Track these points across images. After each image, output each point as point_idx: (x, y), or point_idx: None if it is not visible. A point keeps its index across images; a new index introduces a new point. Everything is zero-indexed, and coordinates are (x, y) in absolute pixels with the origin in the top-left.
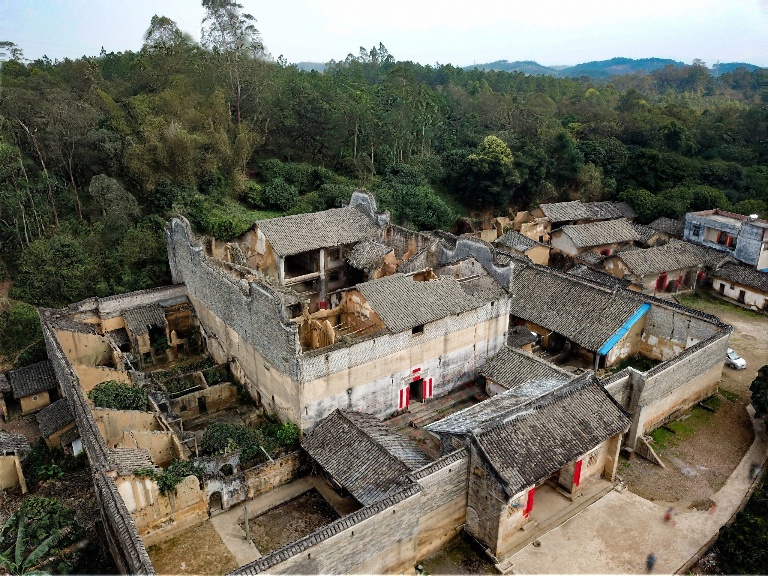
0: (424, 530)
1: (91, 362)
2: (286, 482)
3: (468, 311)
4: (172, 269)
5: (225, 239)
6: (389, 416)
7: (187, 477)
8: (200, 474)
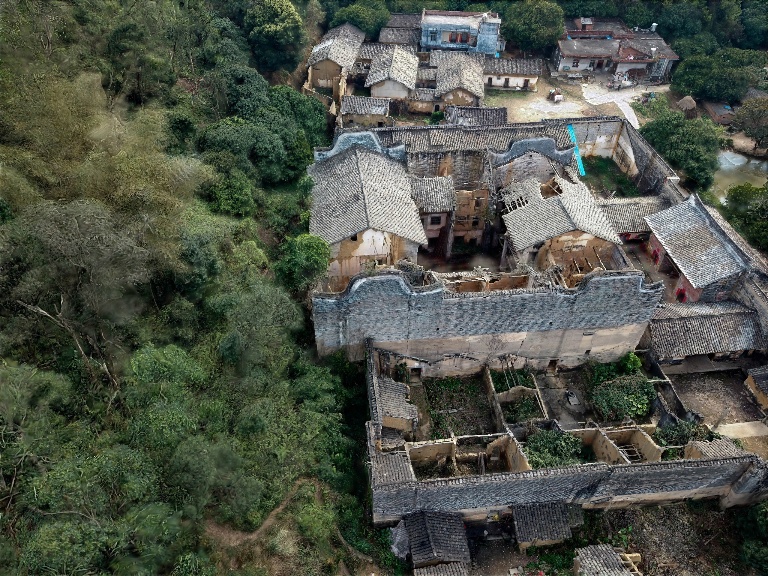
0: None
1: None
2: None
3: None
4: (324, 337)
5: None
6: None
7: None
8: None
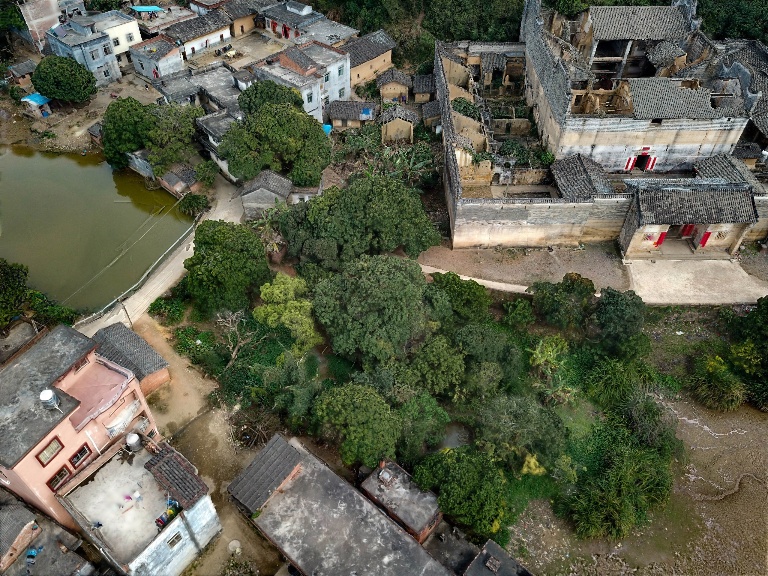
0: (591, 227)
1: (455, 82)
2: (535, 184)
3: (704, 119)
4: (521, 29)
5: (565, 14)
6: (616, 172)
7: (486, 160)
8: (493, 162)
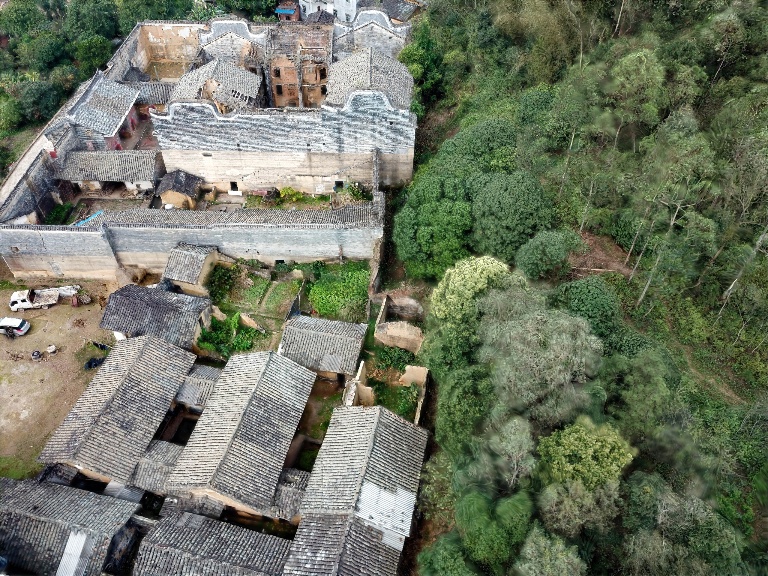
0: None
1: None
2: None
3: None
4: None
5: None
6: None
7: None
8: None
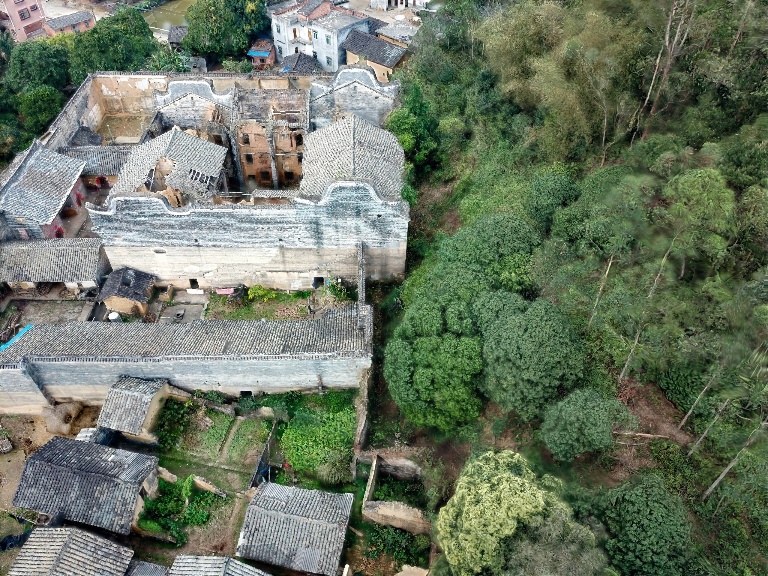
0: None
1: None
2: None
3: None
4: None
5: None
6: None
7: None
8: None
